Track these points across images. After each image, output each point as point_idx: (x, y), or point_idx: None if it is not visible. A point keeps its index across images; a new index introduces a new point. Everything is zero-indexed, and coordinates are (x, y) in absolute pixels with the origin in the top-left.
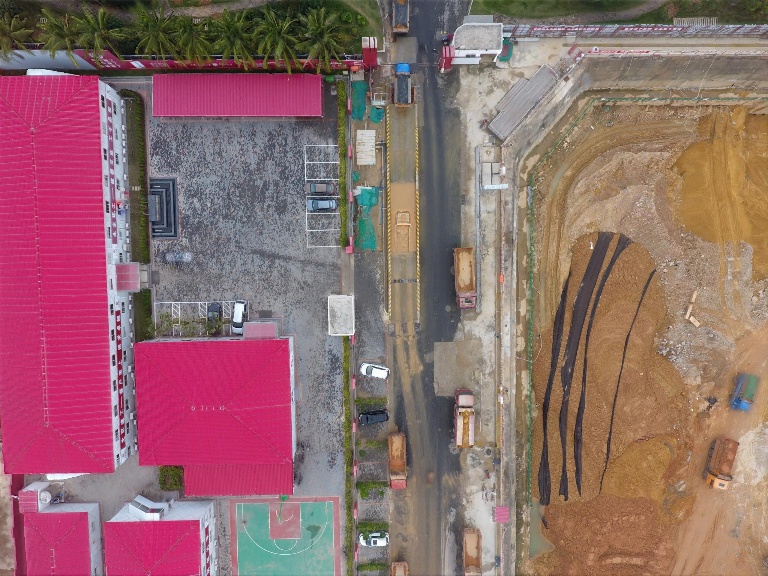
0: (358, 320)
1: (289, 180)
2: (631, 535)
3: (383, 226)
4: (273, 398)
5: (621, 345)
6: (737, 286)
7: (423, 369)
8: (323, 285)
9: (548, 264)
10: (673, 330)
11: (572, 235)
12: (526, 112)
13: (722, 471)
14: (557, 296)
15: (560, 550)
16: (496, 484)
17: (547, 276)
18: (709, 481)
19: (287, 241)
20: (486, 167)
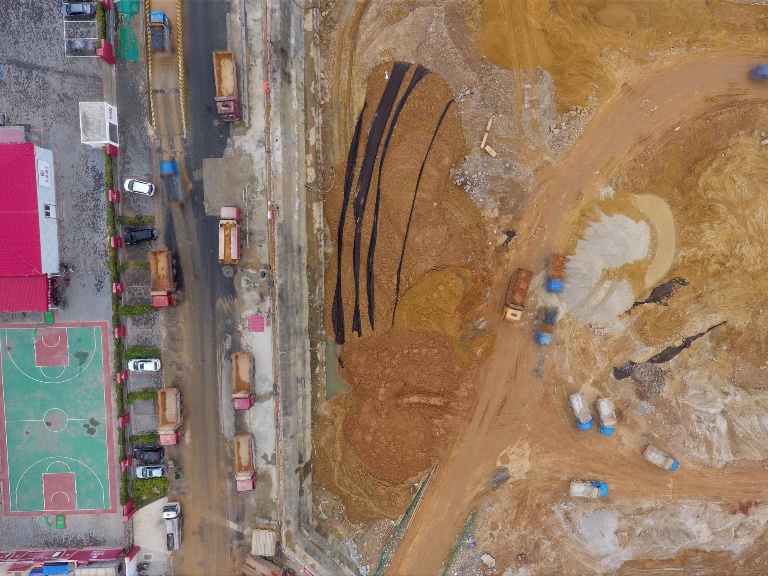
0: (122, 135)
1: None
2: (426, 371)
3: (144, 34)
4: (17, 204)
5: (415, 175)
6: (535, 115)
7: (192, 187)
8: (84, 97)
9: (340, 93)
10: (469, 160)
11: (365, 63)
12: None
13: (515, 301)
14: (351, 127)
15: (356, 390)
16: (271, 308)
17: (340, 106)
18: (504, 313)
19: (44, 51)
20: None
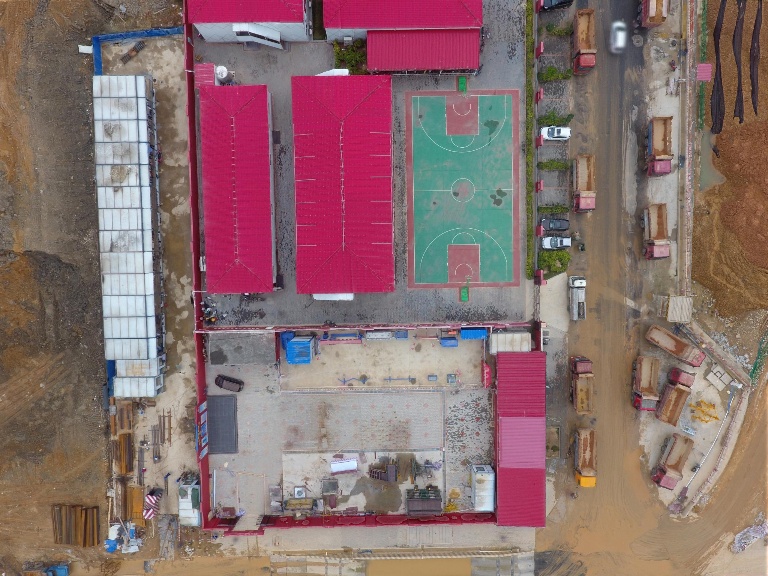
0: None
1: None
2: None
3: None
4: None
5: None
6: None
7: None
8: None
9: None
10: None
11: None
12: None
13: None
14: None
15: (733, 179)
16: (681, 78)
17: None
18: None
19: None
20: None
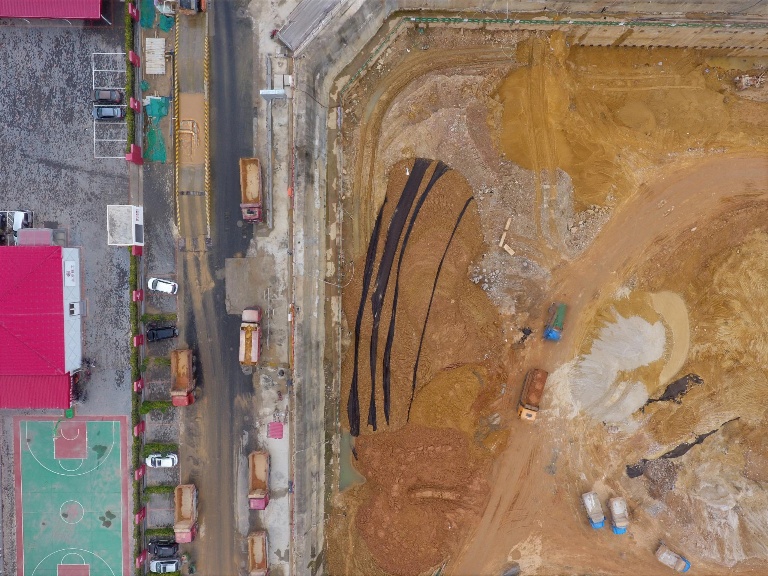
0: (147, 234)
1: (76, 88)
2: (439, 467)
3: (172, 137)
4: (43, 306)
5: (433, 272)
6: (553, 214)
7: (214, 286)
8: (111, 197)
9: (361, 189)
10: (487, 258)
11: (387, 160)
12: (316, 22)
13: (530, 401)
14: (371, 222)
15: (370, 483)
16: (289, 406)
17: (361, 201)
18: (519, 412)
19: (74, 151)
20: (278, 79)
